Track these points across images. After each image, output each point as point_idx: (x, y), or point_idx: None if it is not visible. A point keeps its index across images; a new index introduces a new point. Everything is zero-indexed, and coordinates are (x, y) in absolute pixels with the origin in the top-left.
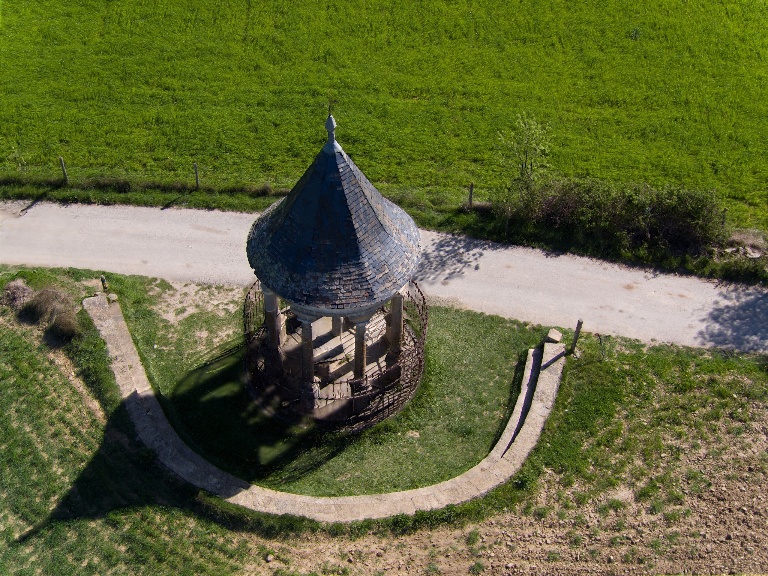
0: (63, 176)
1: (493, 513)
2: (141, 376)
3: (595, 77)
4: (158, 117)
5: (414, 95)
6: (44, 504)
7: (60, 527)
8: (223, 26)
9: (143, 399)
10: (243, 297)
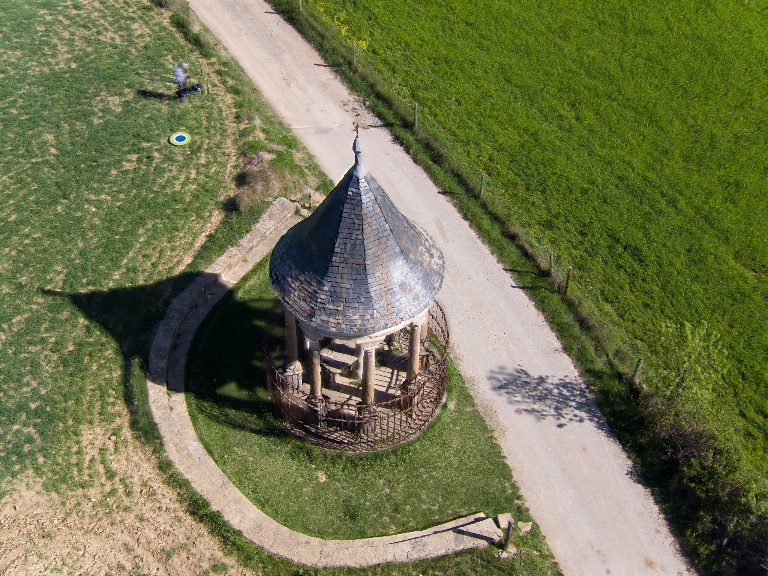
0: (414, 121)
1: (257, 571)
2: (242, 272)
3: None
4: (537, 132)
5: (755, 269)
6: (82, 285)
7: (66, 304)
8: (693, 105)
9: (220, 285)
10: None
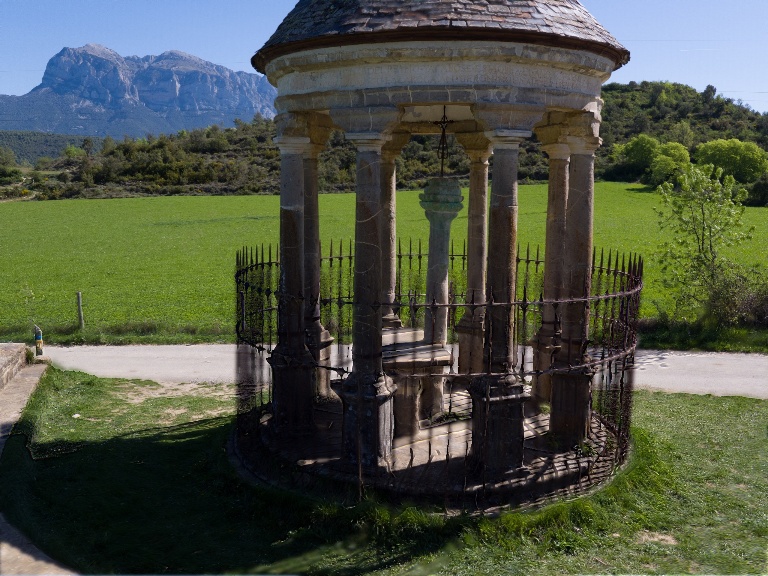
0: (78, 322)
1: None
2: (2, 422)
3: None
4: (220, 308)
5: None
6: None
7: None
8: None
9: None
10: (268, 390)
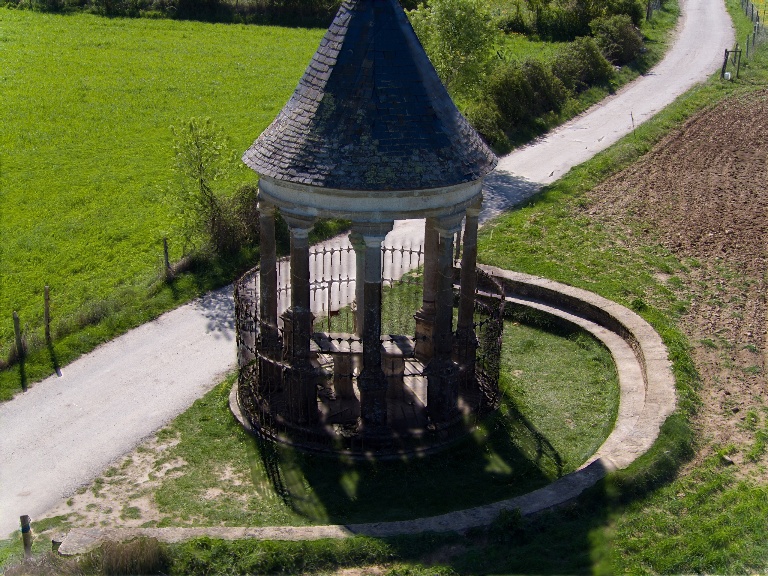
0: None
1: None
2: None
3: (27, 201)
4: None
5: None
6: None
7: None
8: None
9: None
10: (157, 453)
